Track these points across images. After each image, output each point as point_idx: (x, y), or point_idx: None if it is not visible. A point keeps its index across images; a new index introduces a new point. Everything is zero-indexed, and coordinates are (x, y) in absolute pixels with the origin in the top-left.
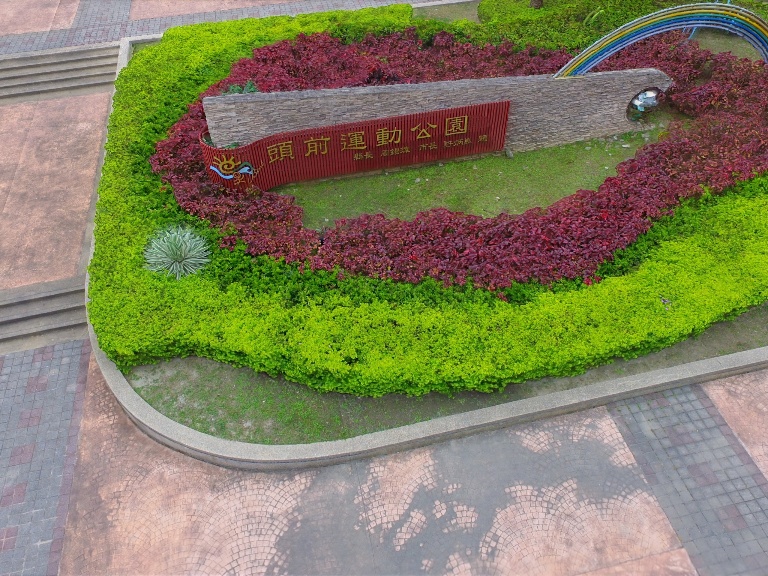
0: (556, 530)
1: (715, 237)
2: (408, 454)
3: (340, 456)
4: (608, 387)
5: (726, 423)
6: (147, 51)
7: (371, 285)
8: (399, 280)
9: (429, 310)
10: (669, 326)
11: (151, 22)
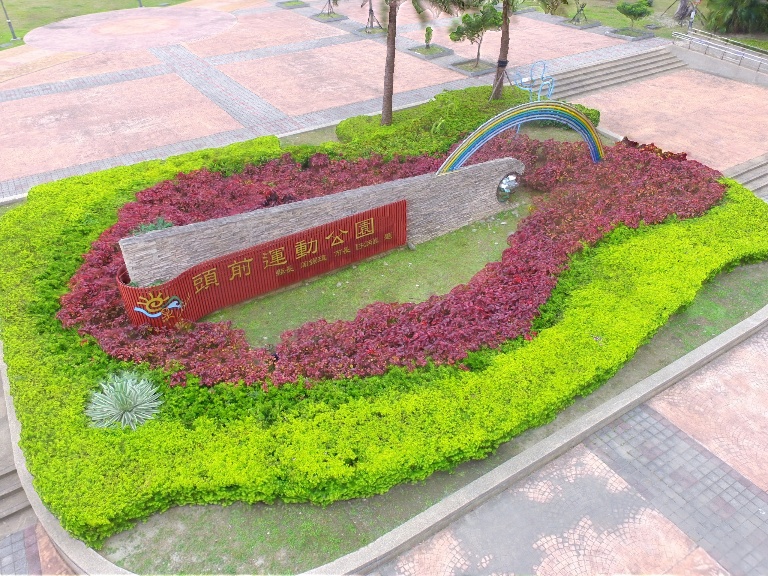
0: (593, 568)
1: (608, 279)
2: (430, 542)
3: (368, 565)
4: (580, 425)
5: (680, 429)
6: (16, 211)
7: (340, 386)
8: (365, 375)
9: (405, 395)
10: (609, 358)
11: (3, 185)
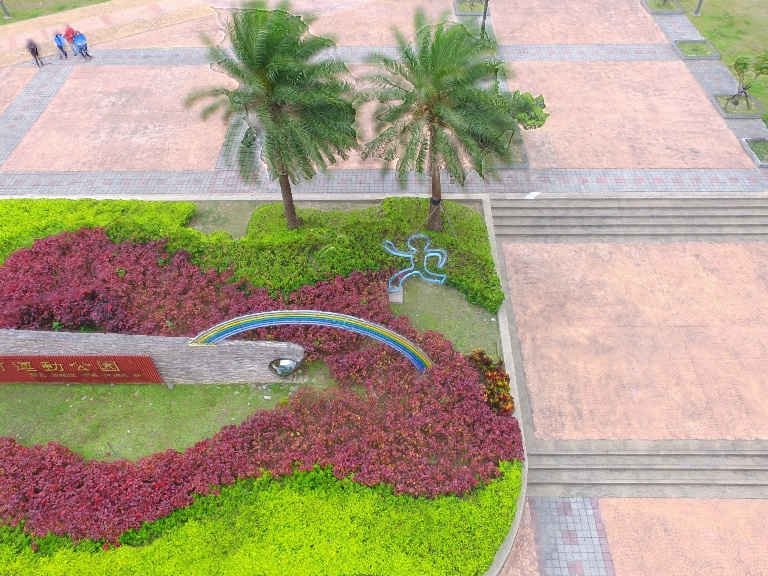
0: None
1: (232, 527)
2: None
3: None
4: None
5: None
6: None
7: None
8: None
9: None
10: None
11: (12, 176)
